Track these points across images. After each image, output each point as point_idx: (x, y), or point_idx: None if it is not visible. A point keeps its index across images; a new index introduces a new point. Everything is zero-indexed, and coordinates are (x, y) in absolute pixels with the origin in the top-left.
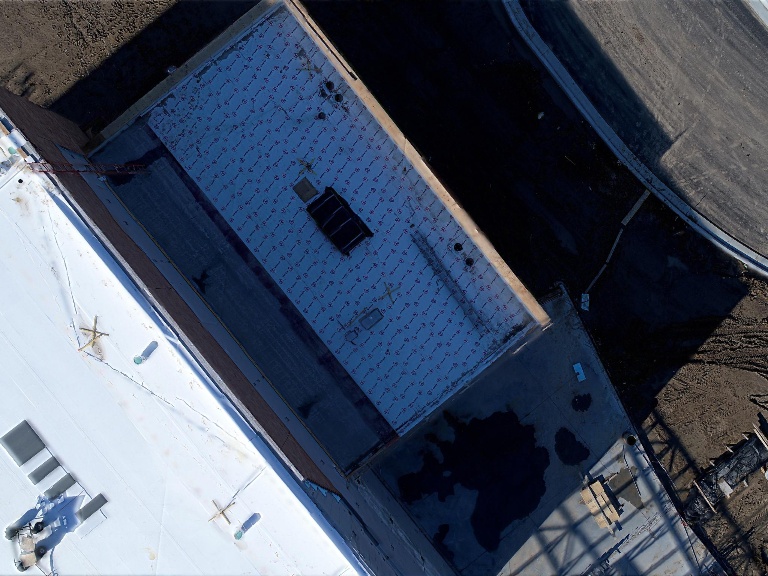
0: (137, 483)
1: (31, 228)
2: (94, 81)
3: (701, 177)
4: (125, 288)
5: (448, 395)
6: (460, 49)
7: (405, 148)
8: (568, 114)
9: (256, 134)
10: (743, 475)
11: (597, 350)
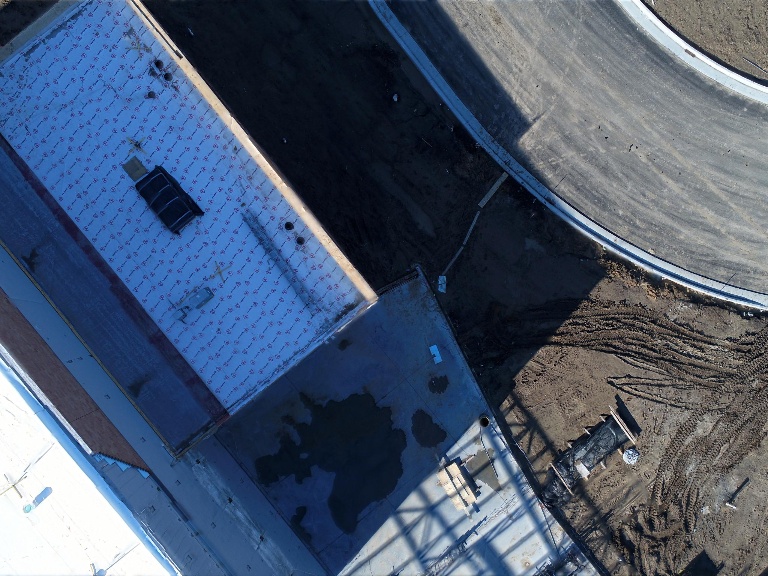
0: None
1: None
2: None
3: (559, 159)
4: None
5: (279, 374)
6: (316, 31)
7: (231, 126)
8: (427, 97)
9: (85, 113)
10: (600, 457)
11: (454, 332)
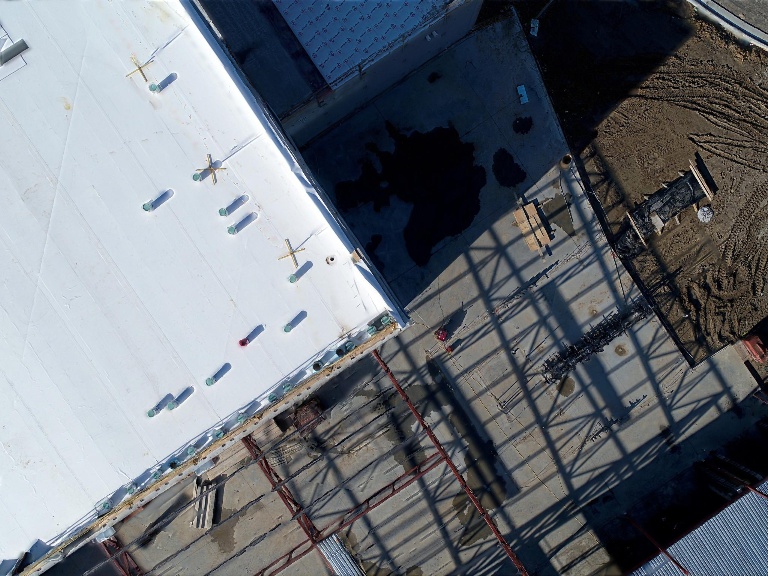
0: (59, 33)
1: None
2: None
3: None
4: None
5: (383, 54)
6: None
7: None
8: None
9: None
10: (675, 211)
11: (542, 76)
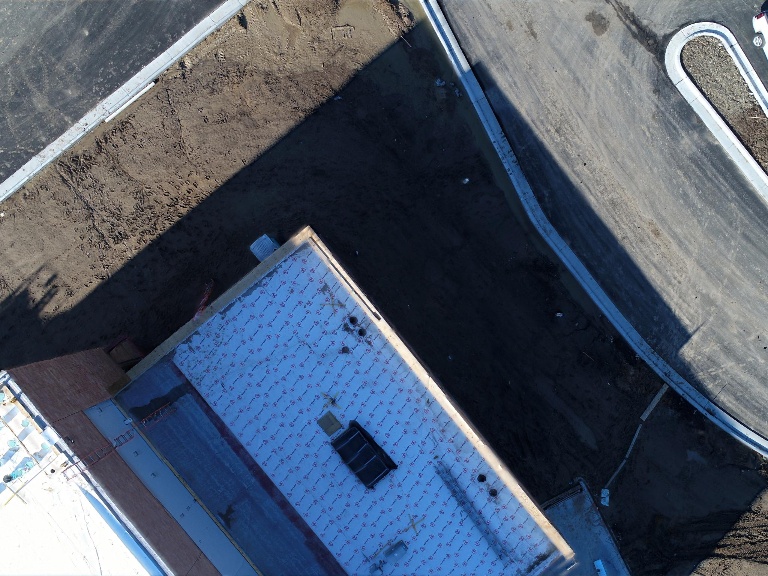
0: None
1: (63, 517)
2: (116, 283)
3: (719, 370)
4: None
5: None
6: (478, 247)
7: (429, 386)
8: (586, 308)
9: (280, 369)
10: None
11: (617, 545)
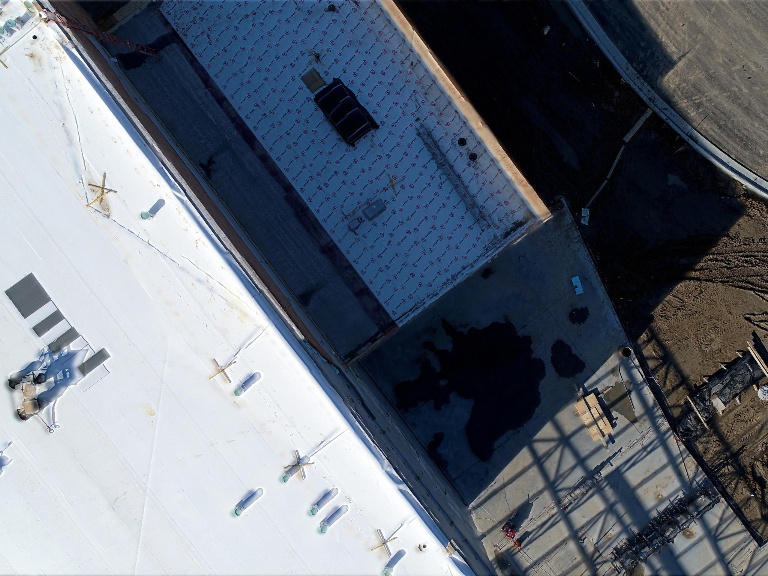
0: (140, 339)
1: (44, 84)
2: None
3: (703, 98)
4: (135, 142)
5: (448, 287)
6: None
7: (413, 40)
8: (574, 32)
9: (266, 23)
10: (736, 392)
11: (595, 264)
